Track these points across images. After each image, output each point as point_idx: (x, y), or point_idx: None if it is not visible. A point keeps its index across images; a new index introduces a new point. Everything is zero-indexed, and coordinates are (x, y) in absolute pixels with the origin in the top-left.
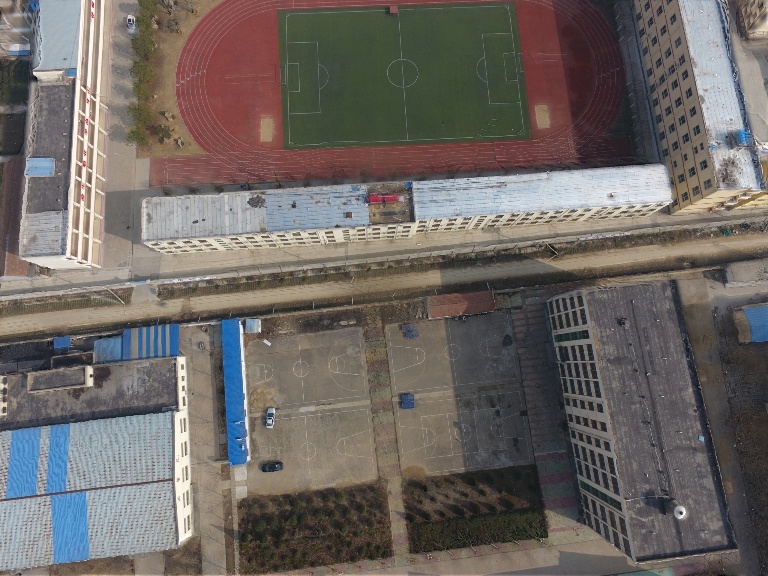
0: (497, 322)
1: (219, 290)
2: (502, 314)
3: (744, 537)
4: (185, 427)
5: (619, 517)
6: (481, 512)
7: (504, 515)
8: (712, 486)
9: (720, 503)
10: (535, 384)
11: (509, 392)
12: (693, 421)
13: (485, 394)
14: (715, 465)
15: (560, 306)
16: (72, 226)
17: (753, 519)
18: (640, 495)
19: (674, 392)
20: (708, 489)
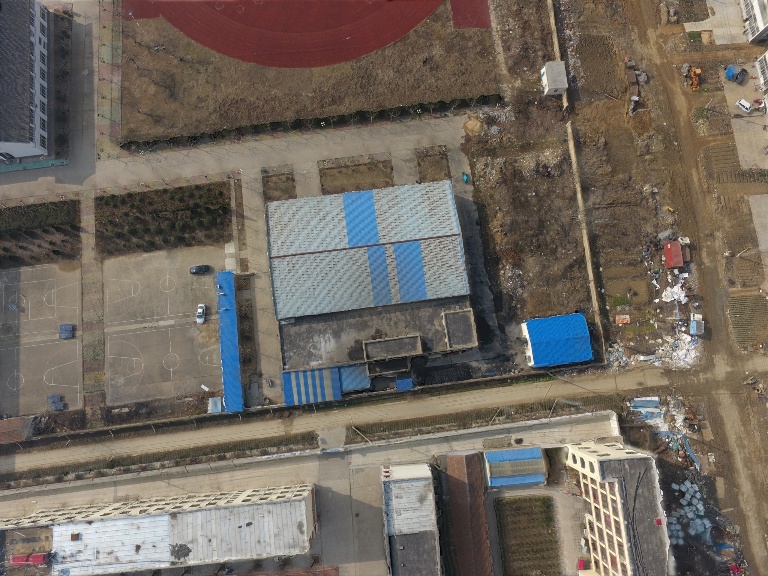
0: None
1: (254, 444)
2: None
3: None
4: None
5: None
6: None
7: None
8: None
9: None
10: None
11: None
12: None
13: None
14: None
15: None
16: (384, 516)
17: None
18: None
19: None
20: None
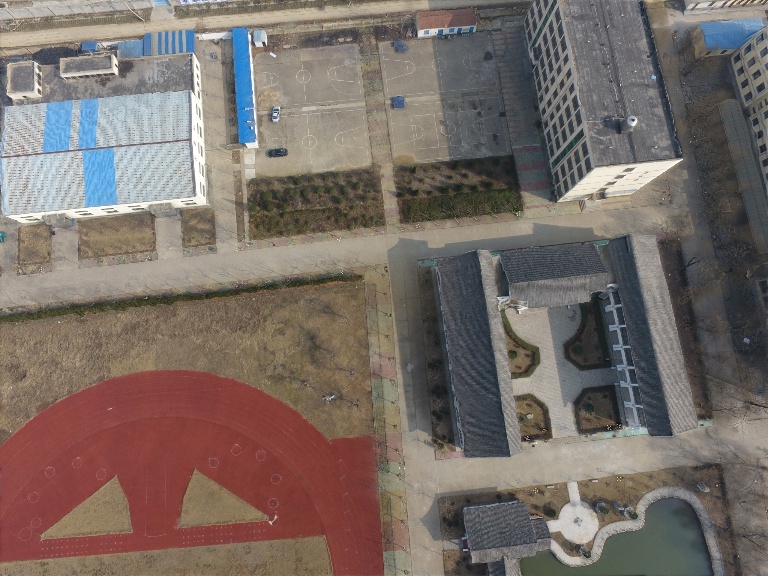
0: (479, 41)
1: (229, 11)
2: (484, 35)
3: (698, 213)
4: (200, 116)
5: (582, 145)
6: (464, 191)
7: (484, 193)
8: (662, 114)
9: (669, 126)
10: (513, 91)
11: (489, 97)
12: (646, 64)
13: (468, 99)
14: (665, 97)
15: (534, 9)
16: None
17: (706, 200)
18: (599, 119)
19: (630, 42)
20: (659, 116)
